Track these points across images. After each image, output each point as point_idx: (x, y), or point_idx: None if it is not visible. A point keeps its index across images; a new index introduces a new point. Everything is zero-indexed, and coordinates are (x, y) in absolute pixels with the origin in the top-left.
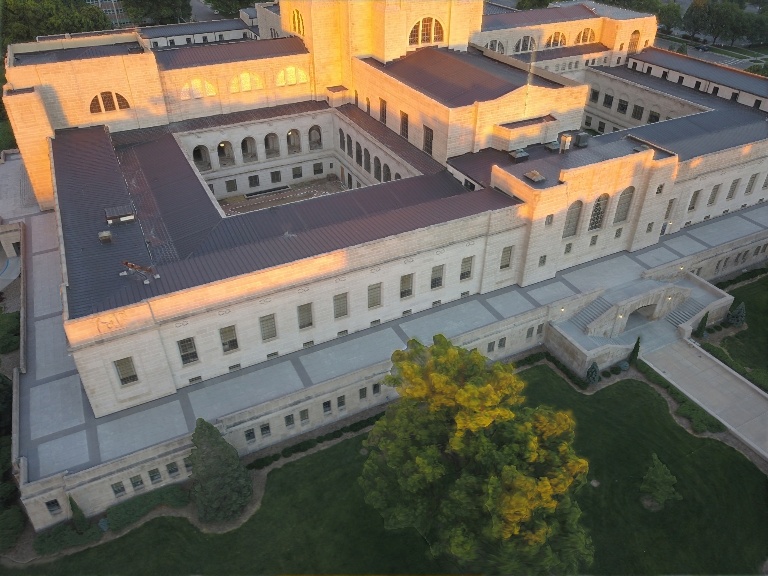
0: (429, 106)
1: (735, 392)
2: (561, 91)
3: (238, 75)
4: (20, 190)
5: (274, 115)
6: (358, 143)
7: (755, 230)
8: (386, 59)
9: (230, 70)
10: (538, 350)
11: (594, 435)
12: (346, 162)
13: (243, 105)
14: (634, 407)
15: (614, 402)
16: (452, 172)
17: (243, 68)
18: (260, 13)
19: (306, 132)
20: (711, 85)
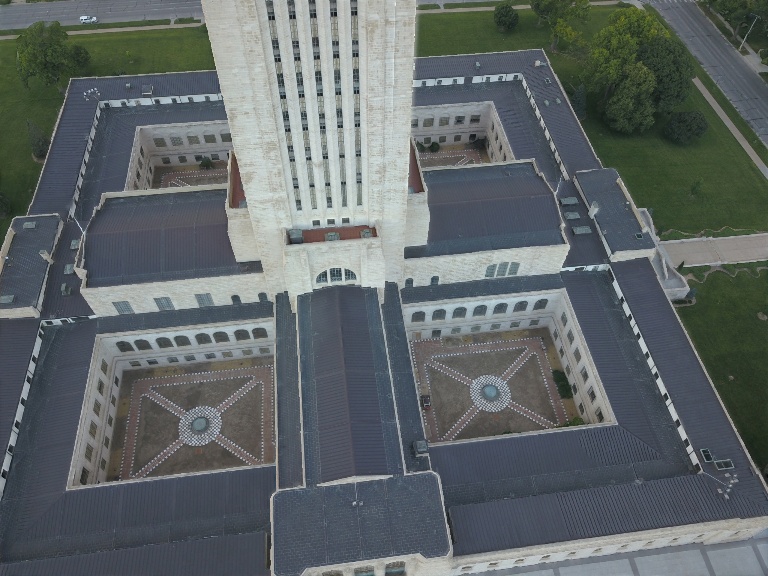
0: None
1: None
2: None
3: None
4: None
5: None
6: None
7: None
8: None
9: None
10: None
11: None
12: None
13: None
14: None
15: None
16: None
17: None
18: None
19: None
20: None
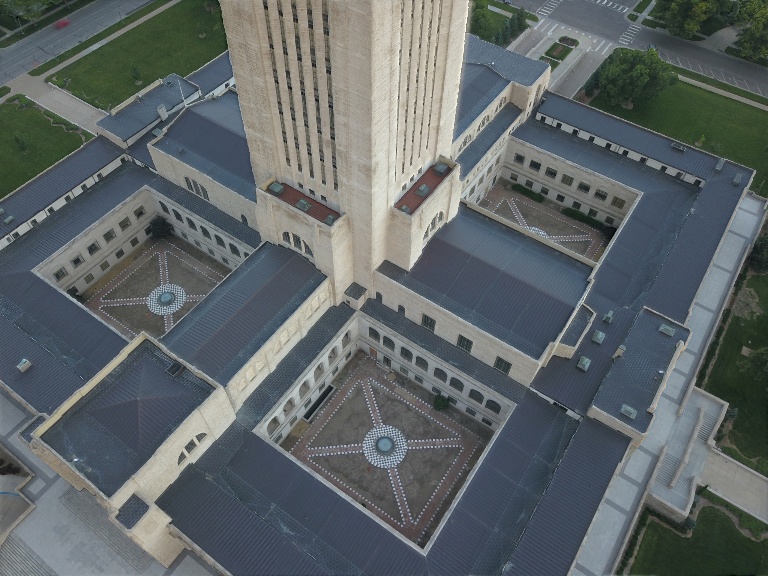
0: (509, 351)
1: (758, 488)
2: None
3: (279, 338)
4: (108, 546)
5: (314, 347)
6: (408, 350)
7: (709, 319)
8: (410, 268)
9: (274, 340)
10: (641, 508)
11: (711, 573)
12: (382, 350)
13: (284, 353)
14: (718, 534)
15: (706, 536)
16: (536, 393)
17: None
18: (159, 156)
19: (341, 342)
20: (621, 149)
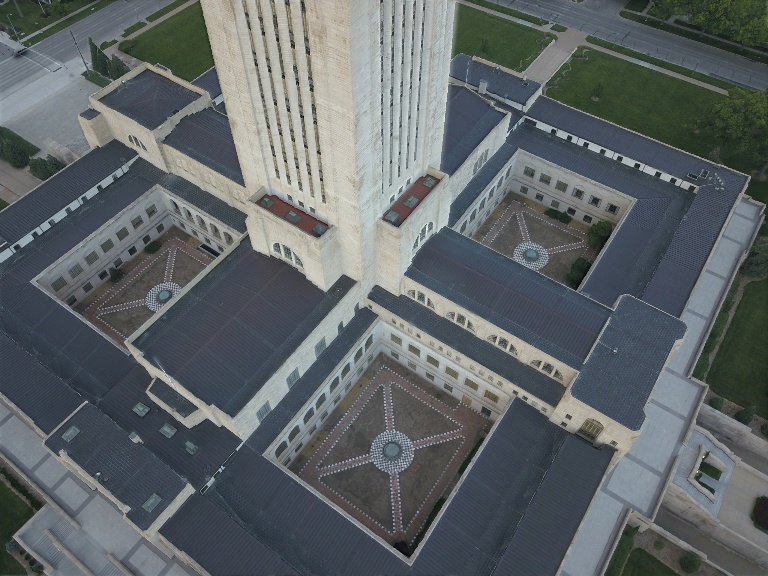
0: None
1: None
2: (202, 405)
3: (207, 174)
4: None
5: (221, 214)
6: None
7: None
8: (254, 248)
9: (201, 168)
10: None
11: None
12: None
13: (213, 192)
14: None
15: (2, 568)
16: None
17: (209, 172)
18: None
19: None
20: None
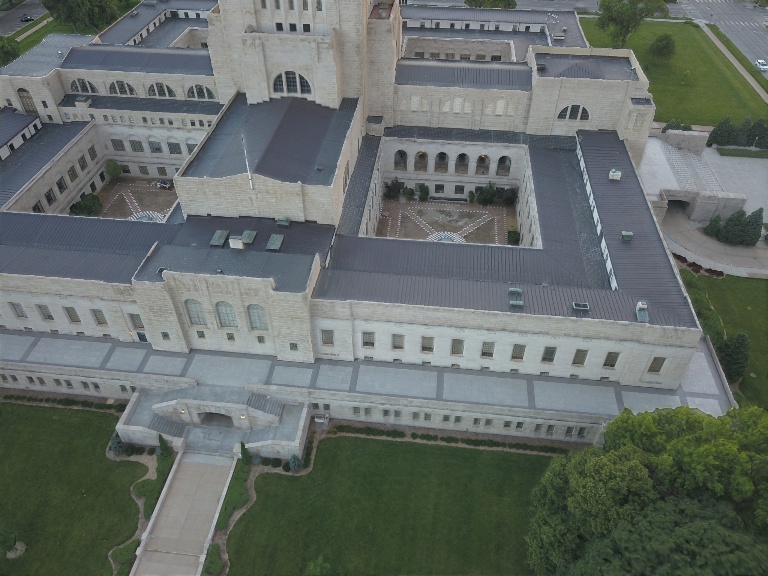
0: None
1: None
2: None
3: None
4: None
5: None
6: None
7: None
8: None
9: None
10: None
11: None
12: None
13: None
14: None
15: None
16: None
17: None
18: None
19: None
20: None
